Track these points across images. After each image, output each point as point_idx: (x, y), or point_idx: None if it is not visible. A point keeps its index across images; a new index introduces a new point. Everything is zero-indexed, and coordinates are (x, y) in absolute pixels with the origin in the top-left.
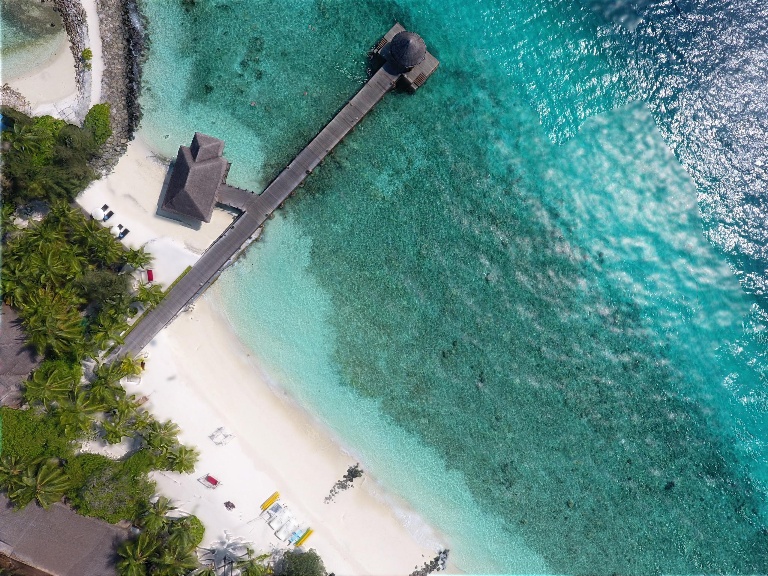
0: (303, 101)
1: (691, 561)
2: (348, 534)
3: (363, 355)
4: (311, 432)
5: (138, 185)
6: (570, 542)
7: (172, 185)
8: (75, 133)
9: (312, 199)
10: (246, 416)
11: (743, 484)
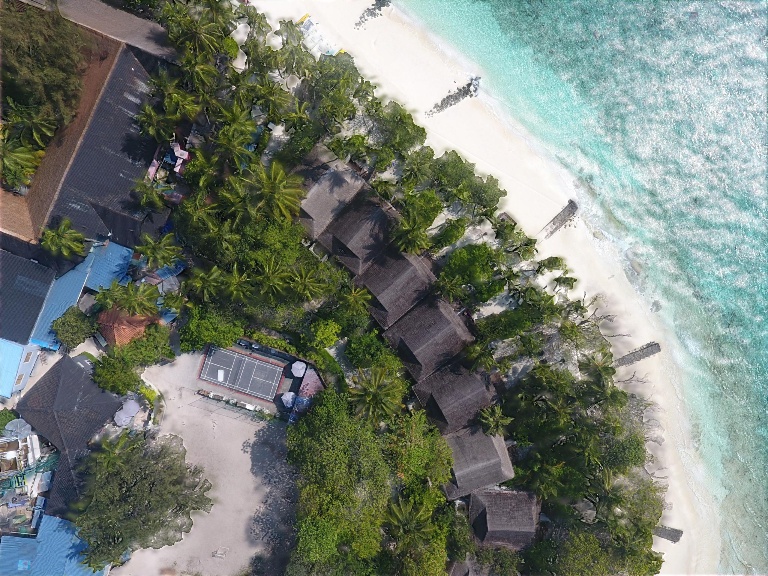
0: None
1: (719, 89)
2: (380, 59)
3: None
4: None
5: None
6: (599, 72)
7: None
8: None
9: None
10: None
11: (766, 16)
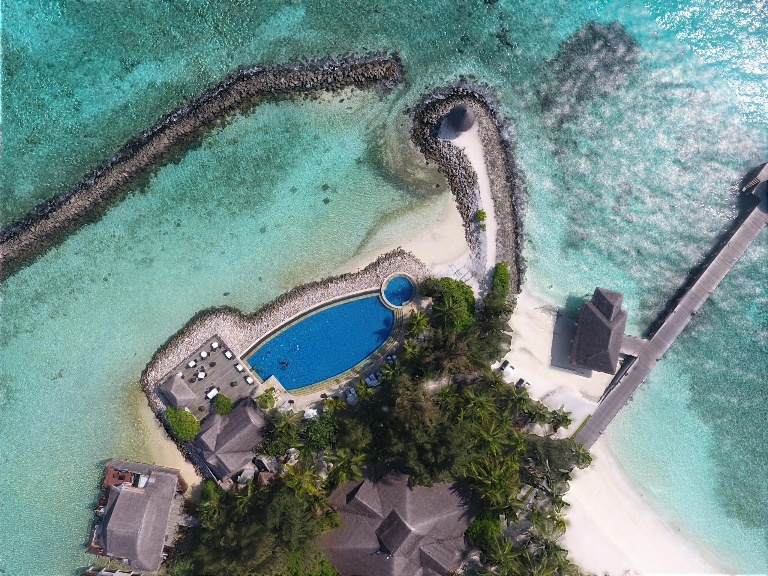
0: (673, 242)
1: None
2: None
3: (747, 487)
4: (705, 566)
5: (531, 338)
6: None
7: (584, 343)
8: (500, 302)
9: (689, 337)
10: (647, 556)
11: None
